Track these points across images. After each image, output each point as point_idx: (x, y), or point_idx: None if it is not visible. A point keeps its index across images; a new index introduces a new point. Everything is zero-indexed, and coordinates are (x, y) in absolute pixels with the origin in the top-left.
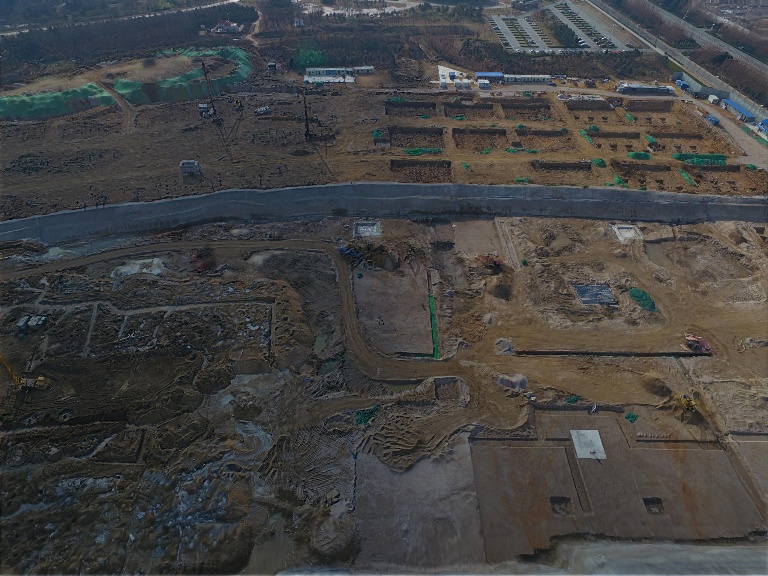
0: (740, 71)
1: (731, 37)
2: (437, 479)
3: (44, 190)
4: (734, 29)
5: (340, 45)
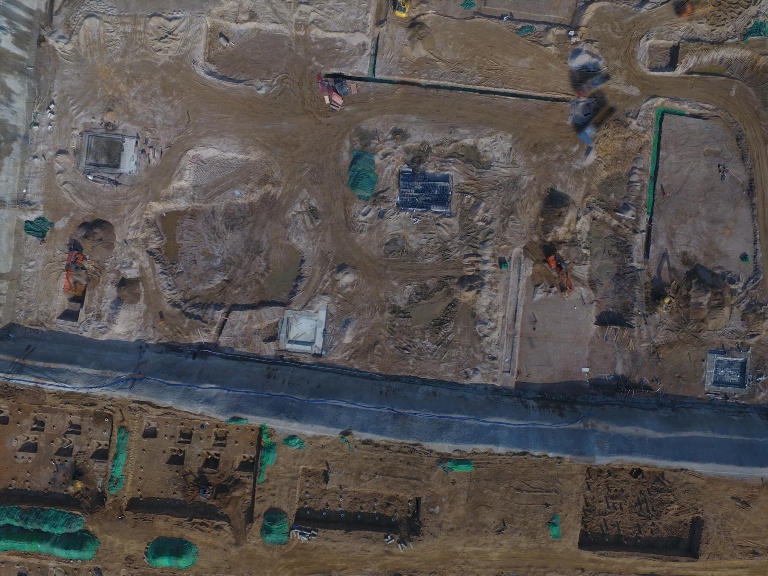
0: None
1: None
2: None
3: None
4: None
5: None
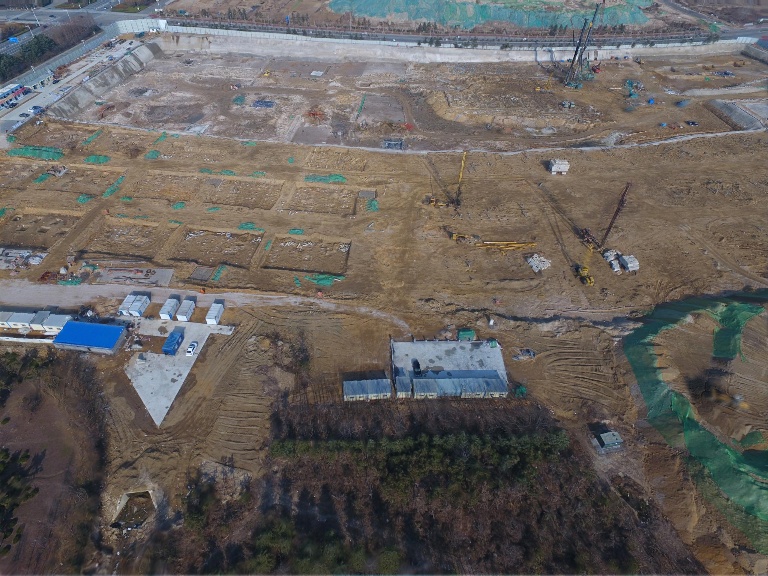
0: None
1: None
2: None
3: (670, 164)
4: None
5: None
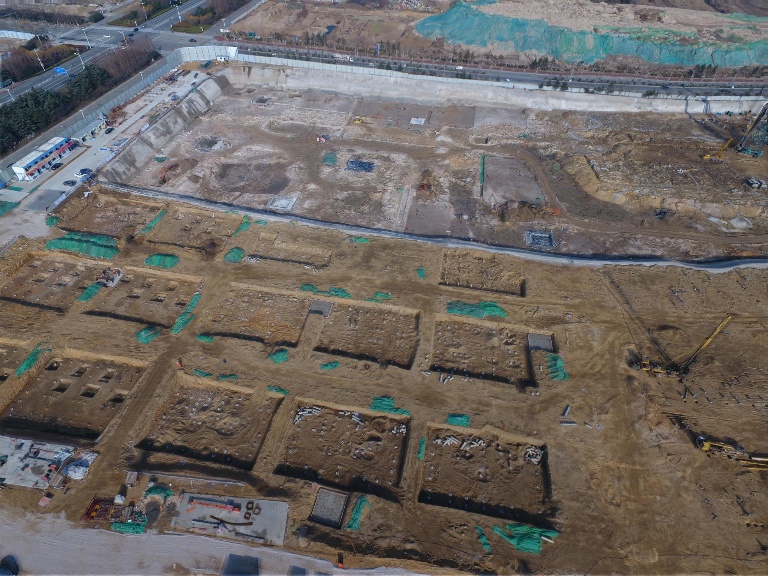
0: None
1: None
2: (491, 120)
3: None
4: None
5: None
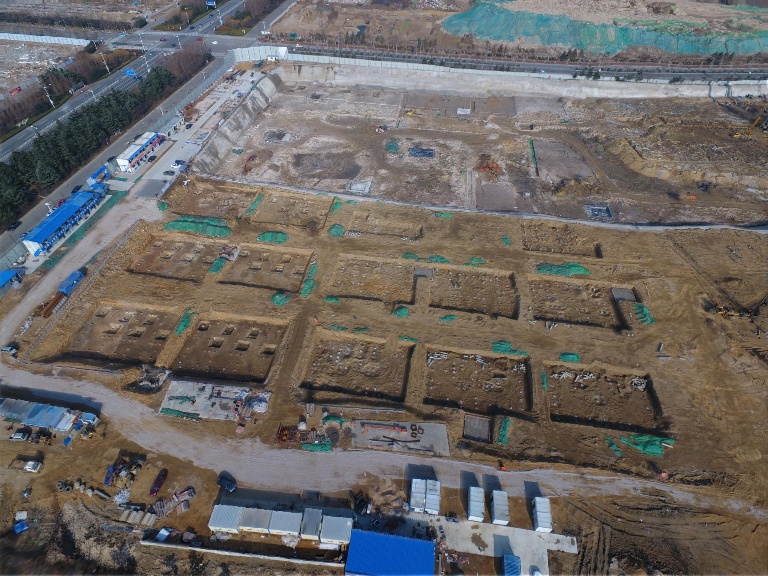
0: None
1: None
2: (531, 108)
3: None
4: None
5: None
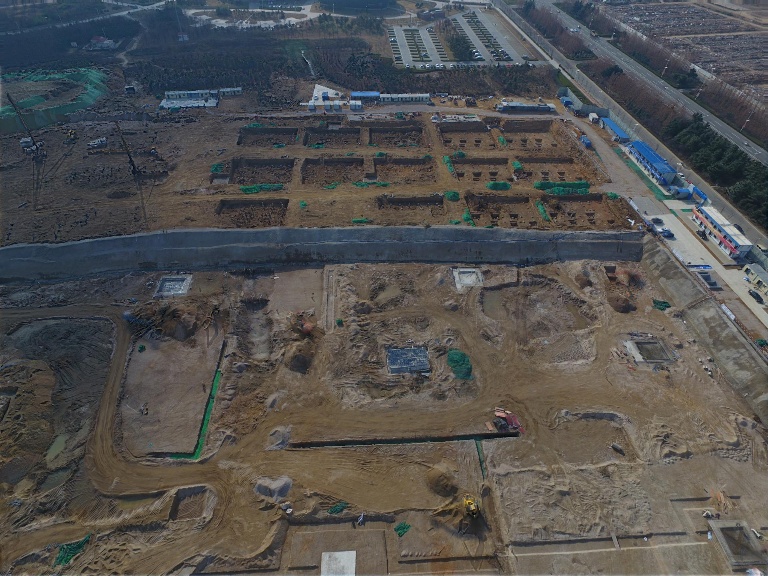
0: (624, 86)
1: (629, 47)
2: None
3: None
4: (632, 39)
5: (214, 63)
